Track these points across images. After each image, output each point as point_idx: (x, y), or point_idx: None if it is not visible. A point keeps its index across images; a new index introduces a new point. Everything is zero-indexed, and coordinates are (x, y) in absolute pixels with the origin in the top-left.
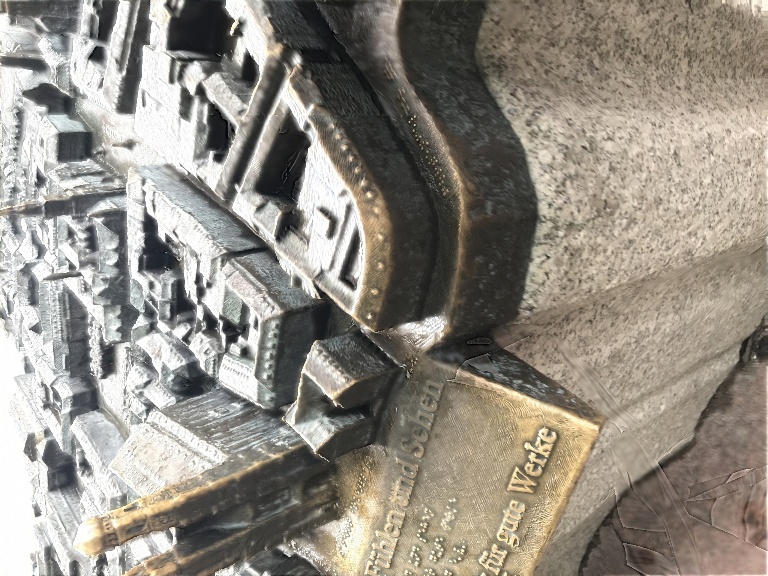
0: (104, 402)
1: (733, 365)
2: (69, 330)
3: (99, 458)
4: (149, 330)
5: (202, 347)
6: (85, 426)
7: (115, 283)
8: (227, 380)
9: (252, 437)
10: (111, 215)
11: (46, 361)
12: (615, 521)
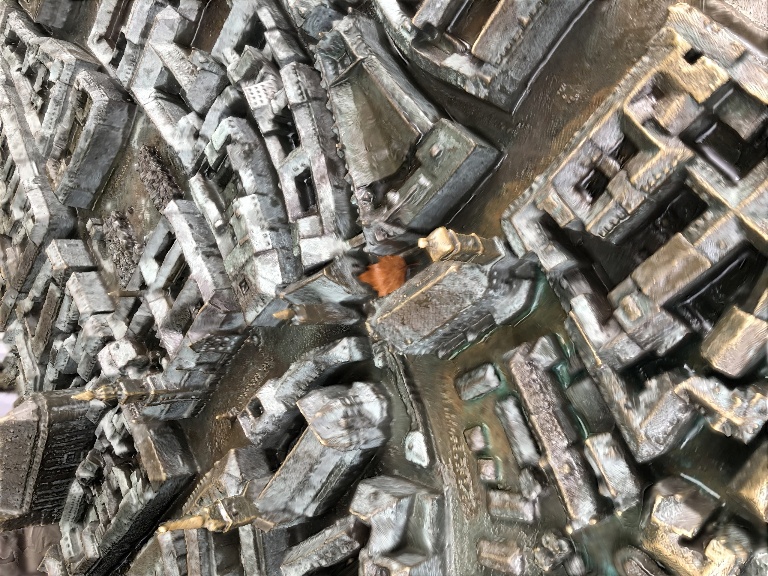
0: (139, 115)
1: None
2: None
3: (78, 168)
4: None
5: (88, 471)
6: (100, 127)
7: None
8: (67, 501)
9: None
10: None
11: None
12: None
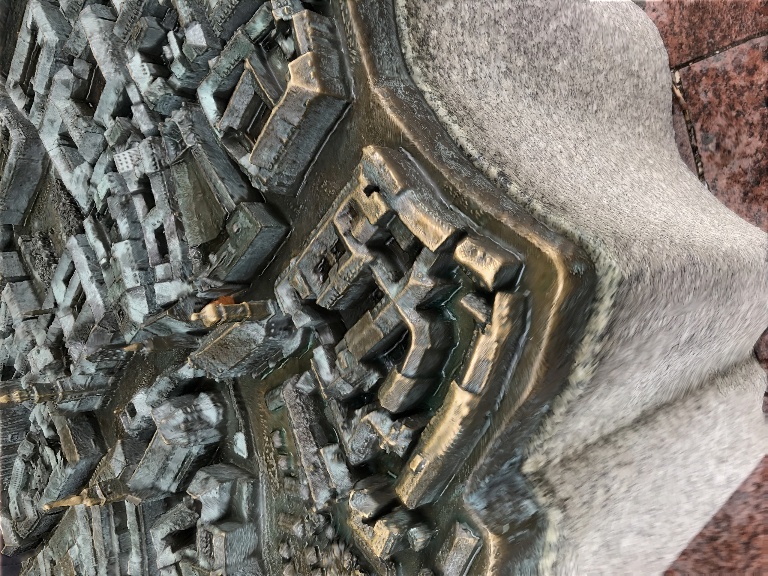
0: None
1: None
2: None
3: (5, 194)
4: None
5: (27, 449)
6: (21, 161)
7: None
8: (13, 472)
9: (2, 471)
10: None
11: (56, 55)
12: None
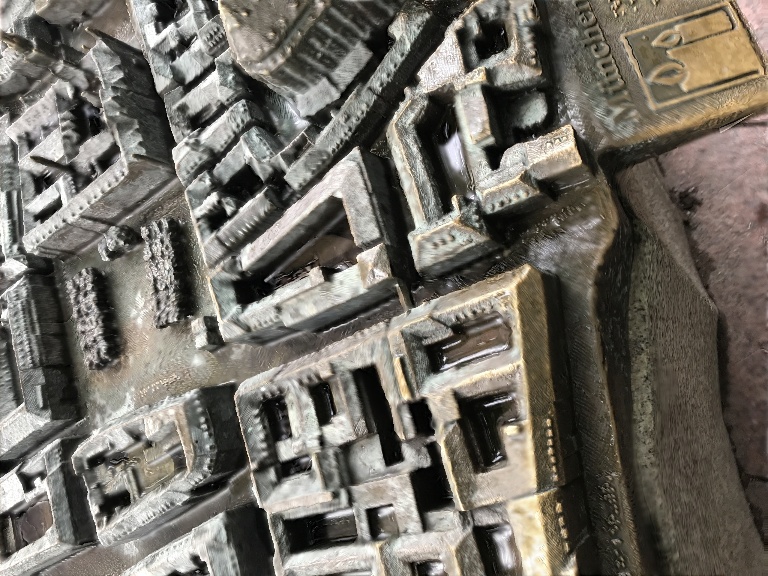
0: None
1: (681, 220)
2: (41, 350)
3: (140, 407)
4: (183, 93)
5: None
6: None
7: (126, 95)
8: None
9: None
10: (108, 38)
11: None
12: (749, 467)
